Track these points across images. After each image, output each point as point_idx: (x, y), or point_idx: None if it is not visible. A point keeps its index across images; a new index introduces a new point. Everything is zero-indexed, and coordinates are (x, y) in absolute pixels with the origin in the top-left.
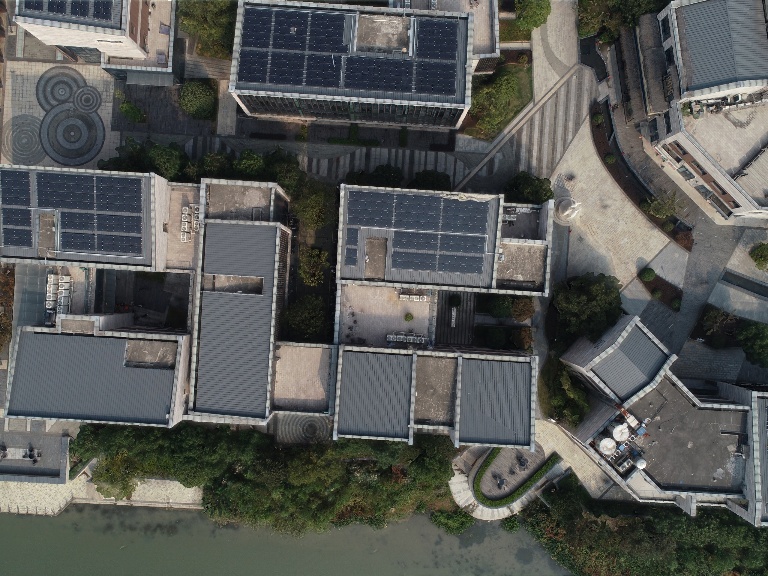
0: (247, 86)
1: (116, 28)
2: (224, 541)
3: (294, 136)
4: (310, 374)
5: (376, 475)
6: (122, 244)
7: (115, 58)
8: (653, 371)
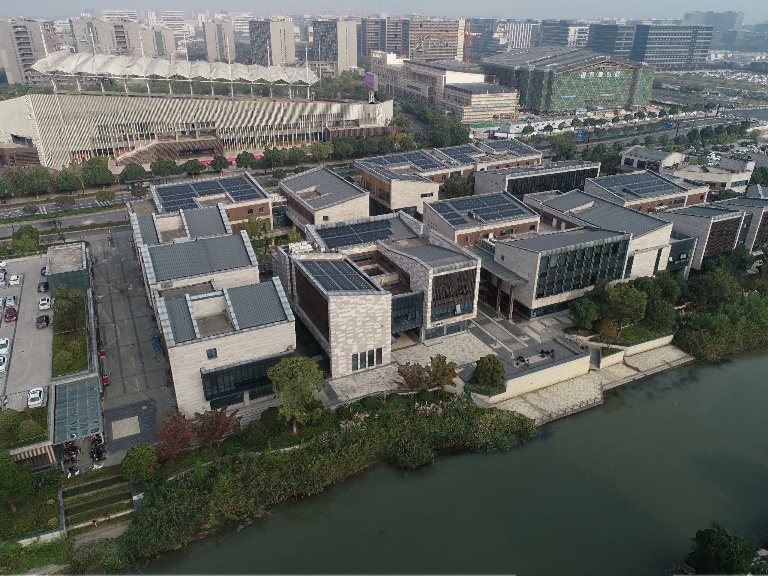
0: None
1: None
2: (734, 371)
3: None
4: None
5: (755, 290)
6: None
7: None
8: None
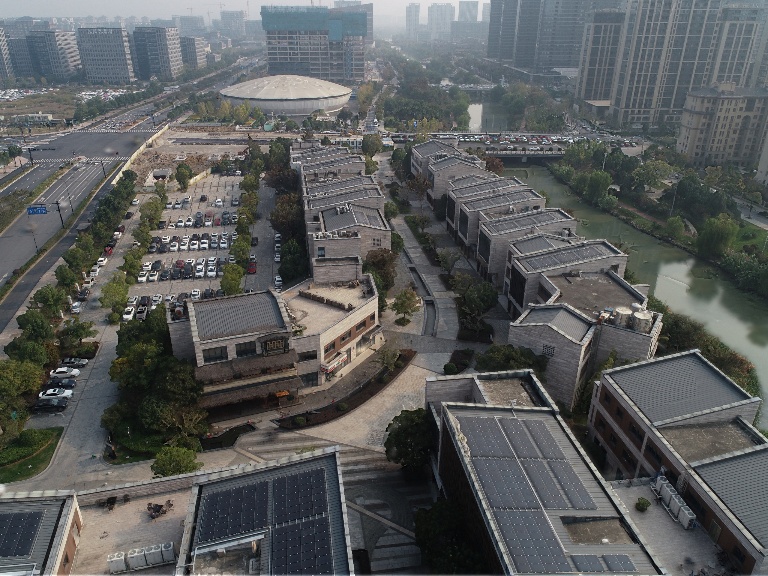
0: None
1: None
2: None
3: None
4: None
5: None
6: None
7: None
8: (552, 310)
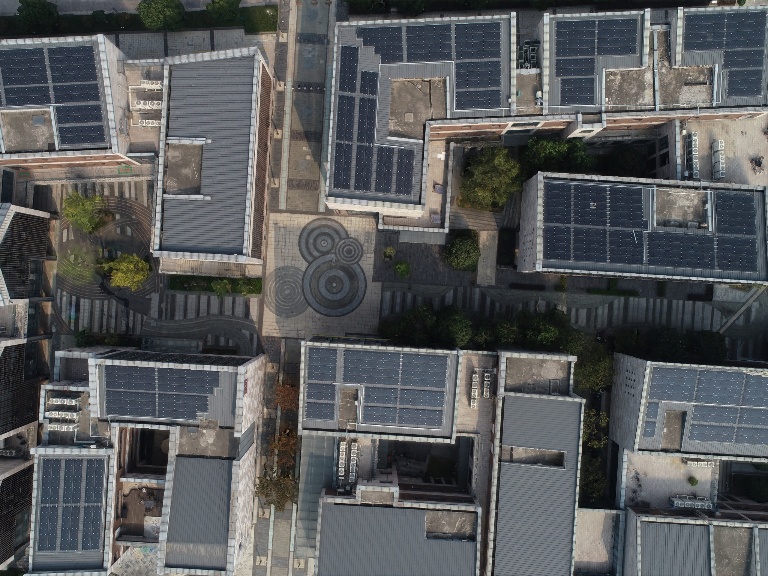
0: (552, 263)
1: (416, 202)
2: None
3: (553, 286)
4: (593, 537)
5: None
6: (423, 417)
7: (389, 217)
8: None
